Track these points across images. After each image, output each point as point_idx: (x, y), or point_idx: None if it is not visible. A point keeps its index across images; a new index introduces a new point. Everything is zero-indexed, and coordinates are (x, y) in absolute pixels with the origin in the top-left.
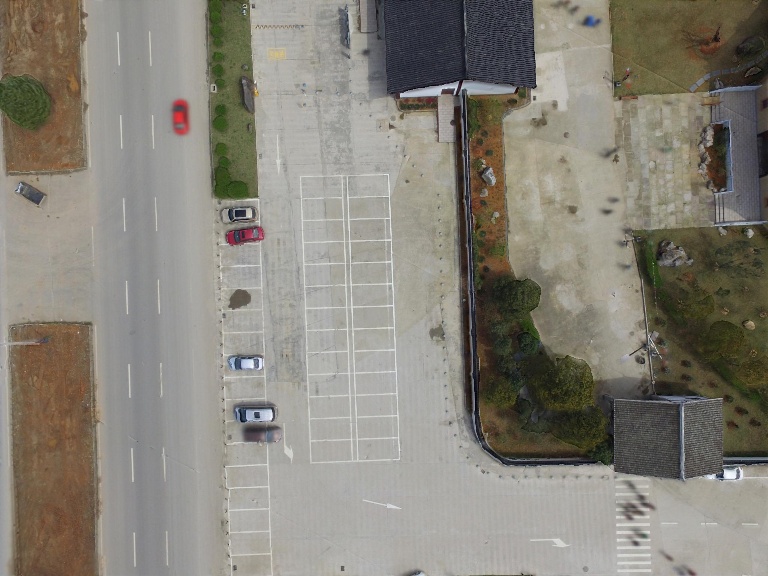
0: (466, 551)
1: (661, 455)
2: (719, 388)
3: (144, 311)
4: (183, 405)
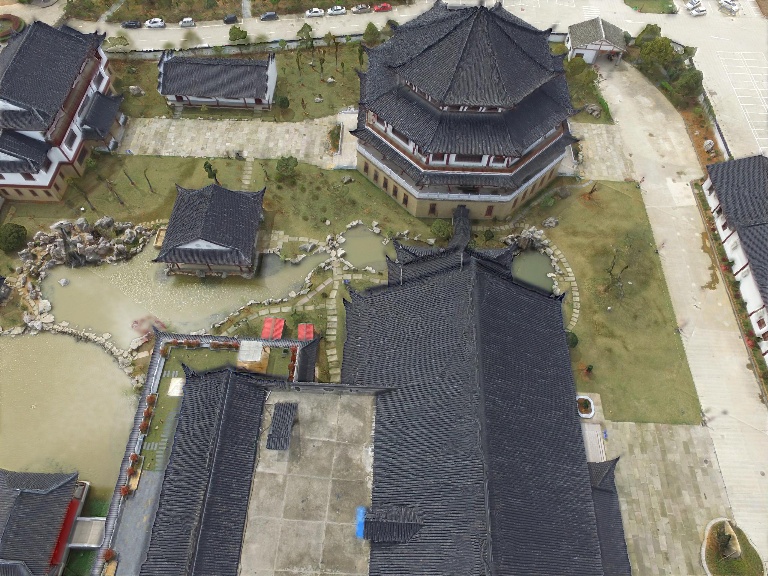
0: (674, 22)
1: None
2: None
3: None
4: None
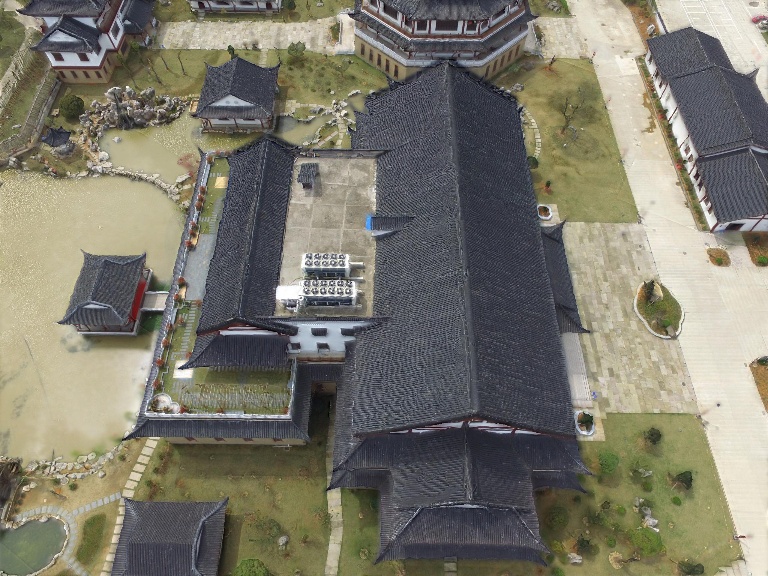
0: None
1: None
2: None
3: None
4: None
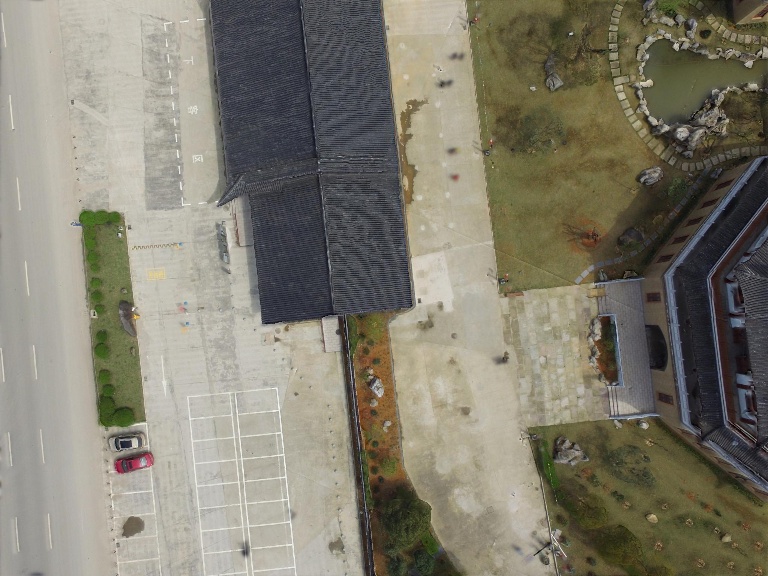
0: None
1: None
2: None
3: (36, 546)
4: None
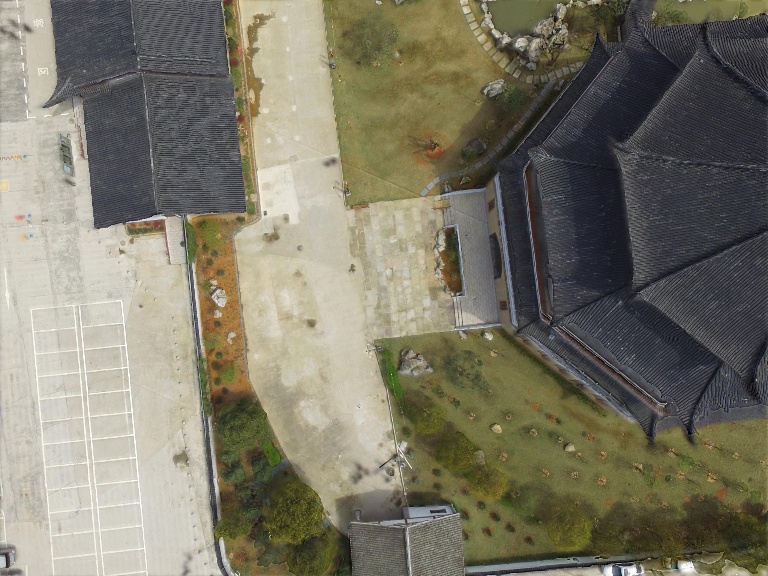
0: None
1: None
2: (473, 494)
3: None
4: None
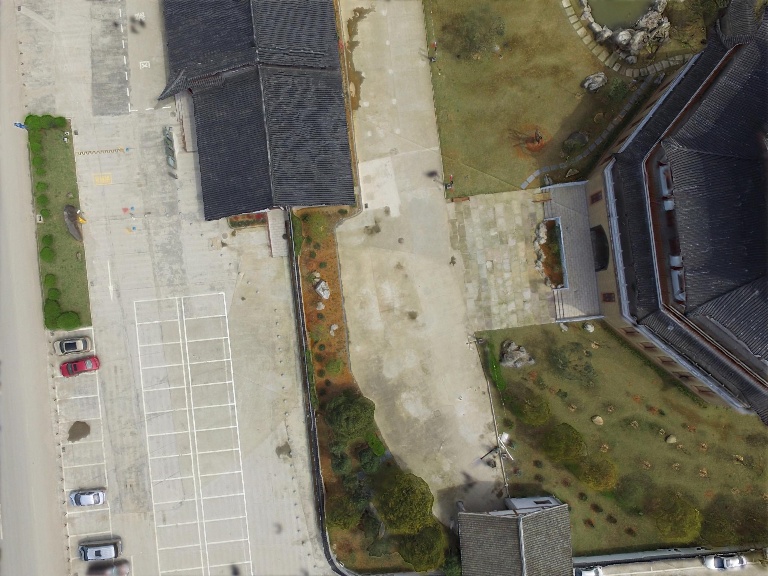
0: None
1: (506, 570)
2: (574, 486)
3: None
4: (25, 546)
